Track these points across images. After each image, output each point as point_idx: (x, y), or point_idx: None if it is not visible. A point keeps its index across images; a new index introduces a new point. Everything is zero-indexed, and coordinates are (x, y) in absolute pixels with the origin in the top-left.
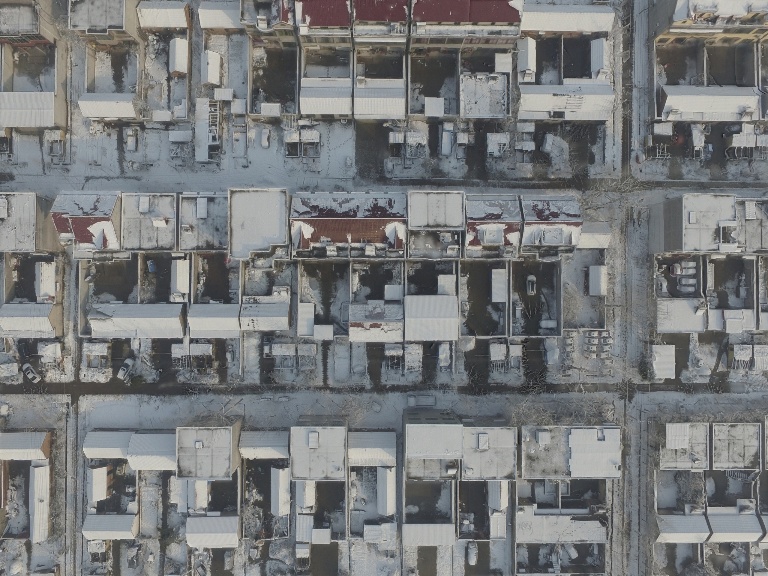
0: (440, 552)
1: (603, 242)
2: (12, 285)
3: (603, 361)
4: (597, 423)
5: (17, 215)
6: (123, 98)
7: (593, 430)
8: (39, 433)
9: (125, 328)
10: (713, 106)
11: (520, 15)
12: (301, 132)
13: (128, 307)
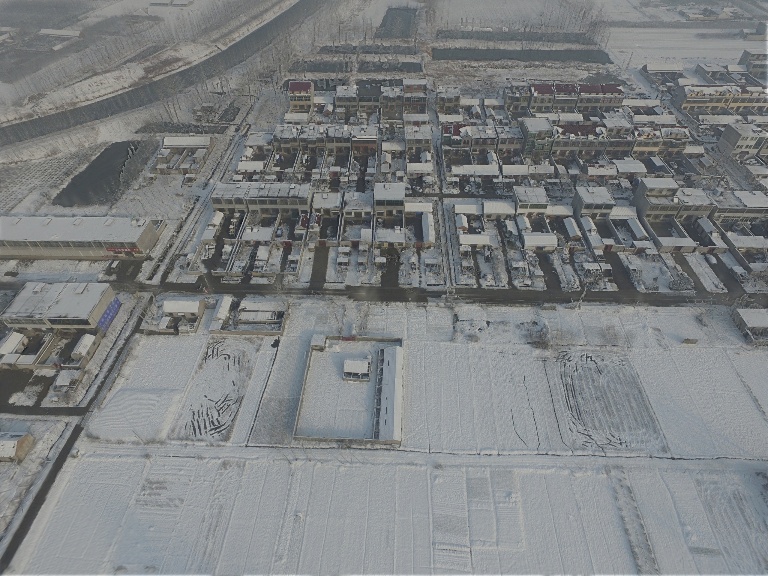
0: (689, 260)
1: (701, 150)
2: None
3: (732, 189)
4: (746, 190)
5: None
6: None
7: (746, 191)
8: None
9: (469, 171)
10: (722, 119)
11: (623, 91)
12: None
13: None
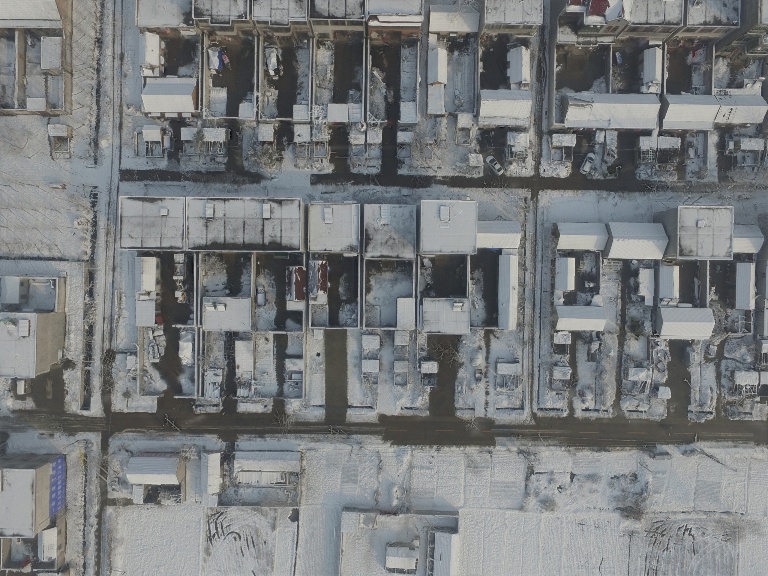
0: None
1: None
2: None
3: None
4: None
5: None
6: None
7: None
8: (512, 221)
9: (599, 117)
10: None
11: None
12: None
13: (603, 96)
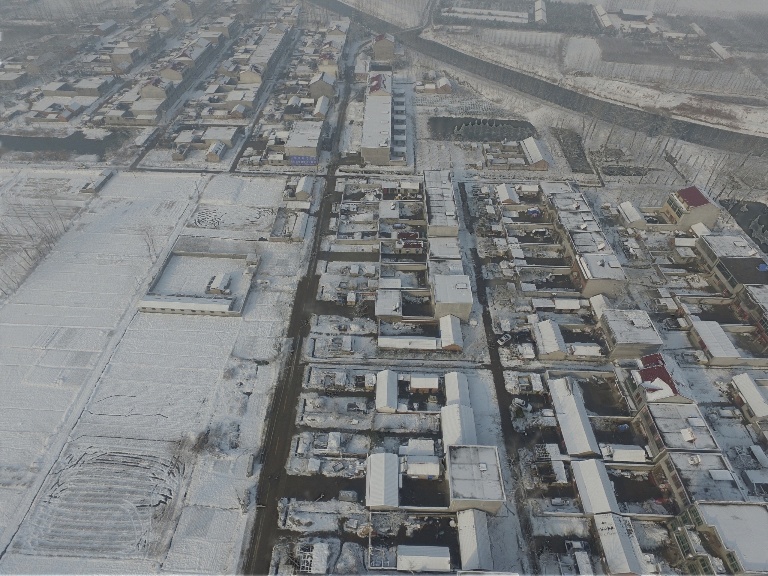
0: None
1: None
2: (569, 329)
3: None
4: None
5: (640, 332)
6: None
7: None
8: None
9: (563, 405)
10: None
11: None
12: None
13: (583, 407)
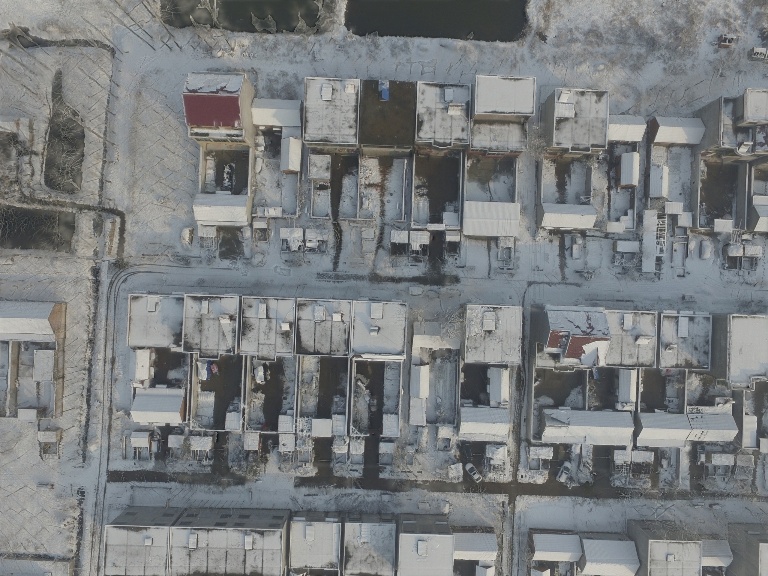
0: None
1: None
2: None
3: None
4: None
5: (504, 328)
6: (585, 211)
7: None
8: (489, 534)
9: (575, 434)
10: None
11: None
12: (745, 247)
13: (579, 414)
